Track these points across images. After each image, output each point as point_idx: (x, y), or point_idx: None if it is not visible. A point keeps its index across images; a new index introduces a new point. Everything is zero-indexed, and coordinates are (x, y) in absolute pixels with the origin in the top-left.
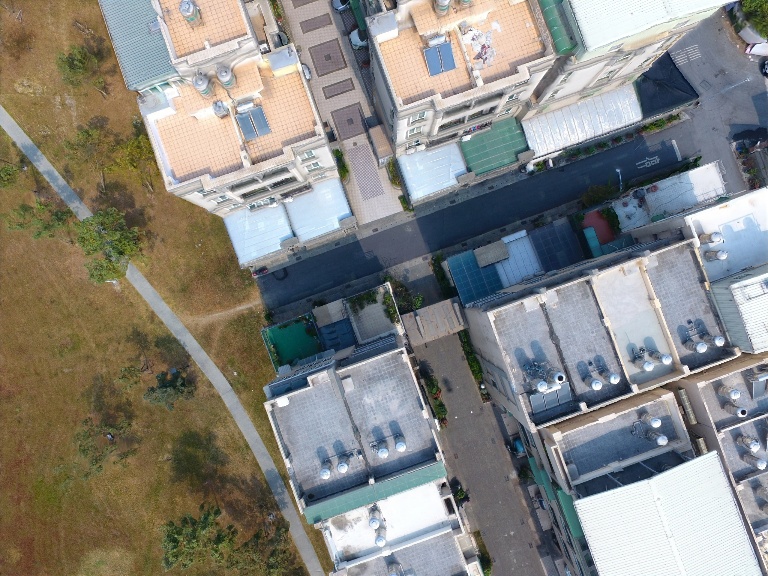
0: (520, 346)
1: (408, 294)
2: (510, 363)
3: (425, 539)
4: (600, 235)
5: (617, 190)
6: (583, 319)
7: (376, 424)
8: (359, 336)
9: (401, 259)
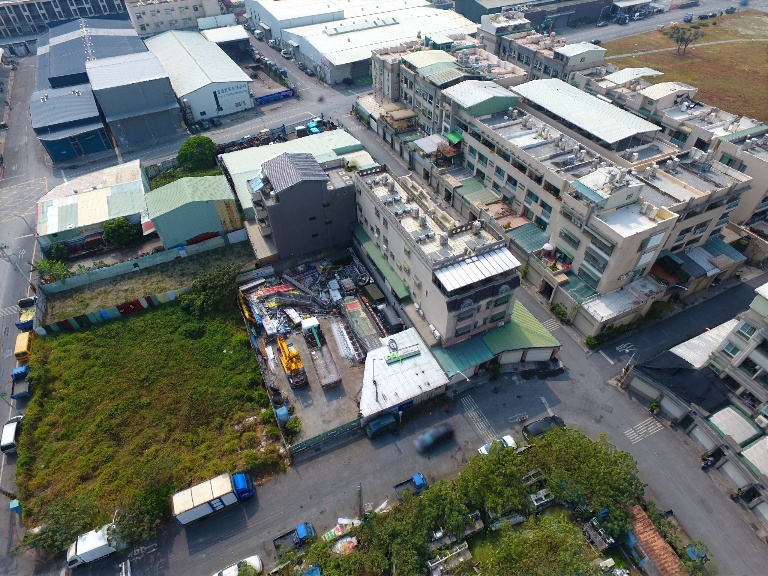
0: (718, 176)
1: (753, 245)
2: (717, 171)
3: (706, 127)
4: (658, 274)
5: (638, 328)
6: (694, 186)
7: (761, 153)
8: (766, 224)
9: (761, 278)
